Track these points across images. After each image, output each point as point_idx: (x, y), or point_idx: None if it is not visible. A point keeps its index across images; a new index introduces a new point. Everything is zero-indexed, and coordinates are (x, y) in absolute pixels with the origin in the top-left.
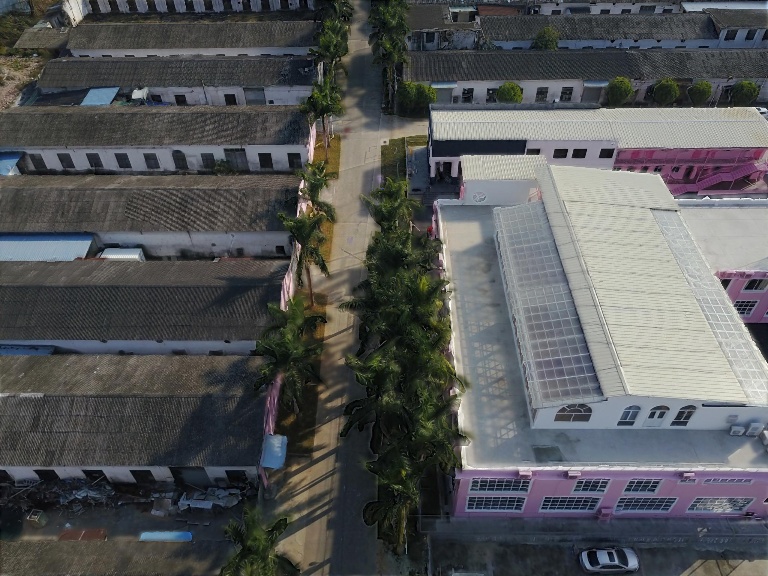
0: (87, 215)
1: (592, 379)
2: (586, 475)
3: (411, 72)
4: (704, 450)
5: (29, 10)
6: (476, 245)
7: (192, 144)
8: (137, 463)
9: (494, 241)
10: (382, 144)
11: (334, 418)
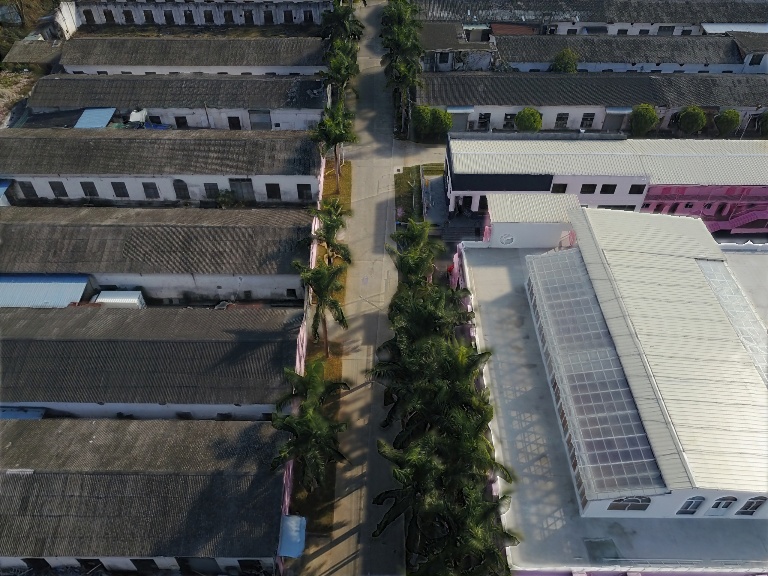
0: (82, 254)
1: (651, 466)
2: (646, 575)
3: (425, 95)
4: None
5: (19, 21)
6: (506, 294)
7: (195, 173)
8: (139, 553)
9: (525, 290)
10: (395, 172)
11: (355, 490)
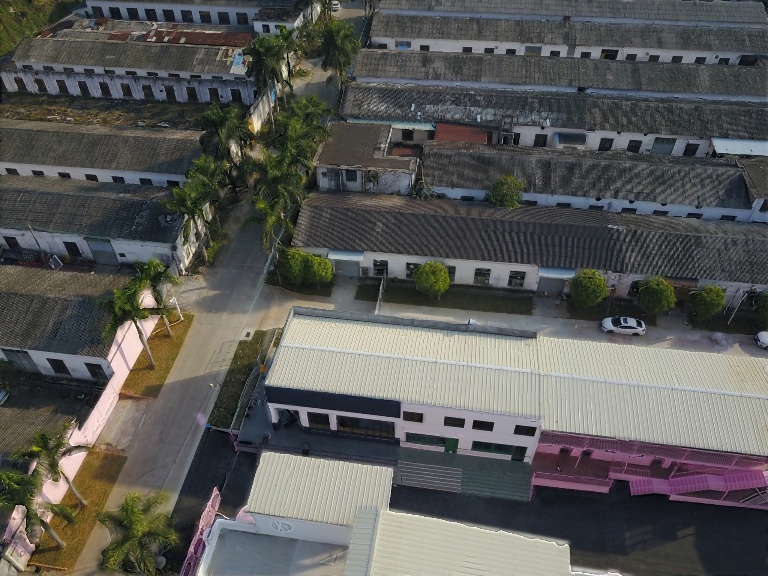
0: None
1: None
2: None
3: (305, 232)
4: None
5: None
6: None
7: None
8: None
9: None
10: (242, 338)
11: None
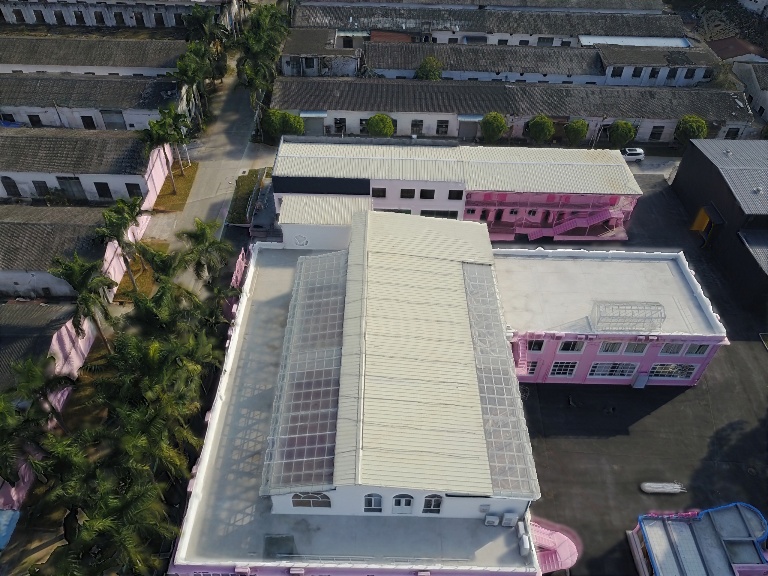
0: None
1: (329, 463)
2: (313, 572)
3: (280, 99)
4: (452, 543)
5: None
6: (283, 295)
7: (20, 171)
8: None
9: None
10: (240, 174)
11: None
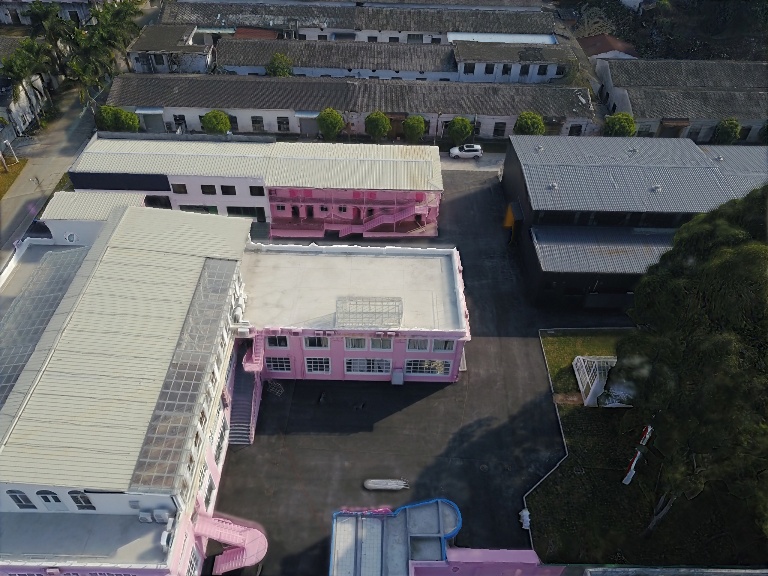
0: None
1: None
2: None
3: (117, 96)
4: (98, 539)
5: None
6: None
7: None
8: None
9: None
10: None
11: None
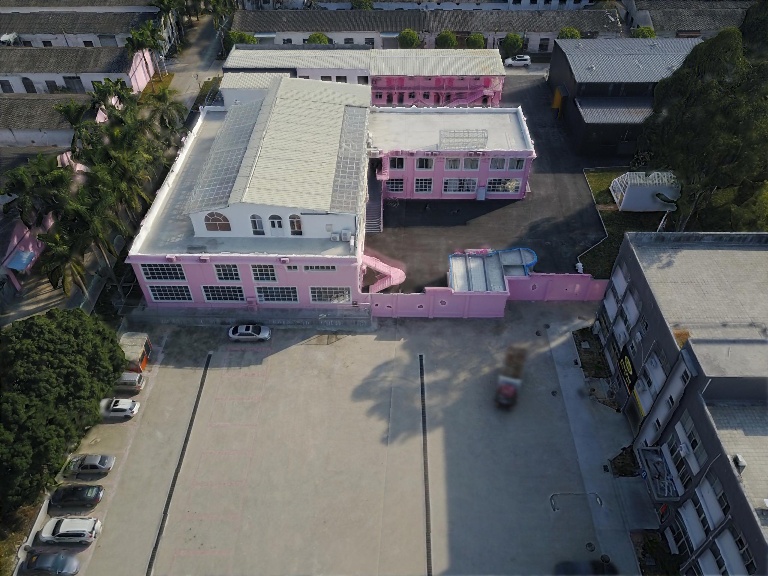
0: None
1: (227, 196)
2: (216, 260)
3: (239, 25)
4: (307, 248)
5: None
6: None
7: (36, 72)
8: None
9: None
10: (206, 80)
11: (87, 252)
